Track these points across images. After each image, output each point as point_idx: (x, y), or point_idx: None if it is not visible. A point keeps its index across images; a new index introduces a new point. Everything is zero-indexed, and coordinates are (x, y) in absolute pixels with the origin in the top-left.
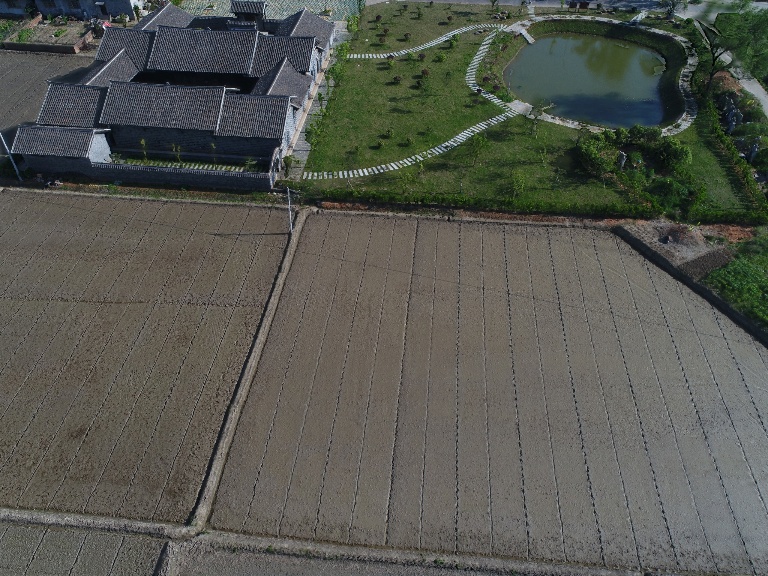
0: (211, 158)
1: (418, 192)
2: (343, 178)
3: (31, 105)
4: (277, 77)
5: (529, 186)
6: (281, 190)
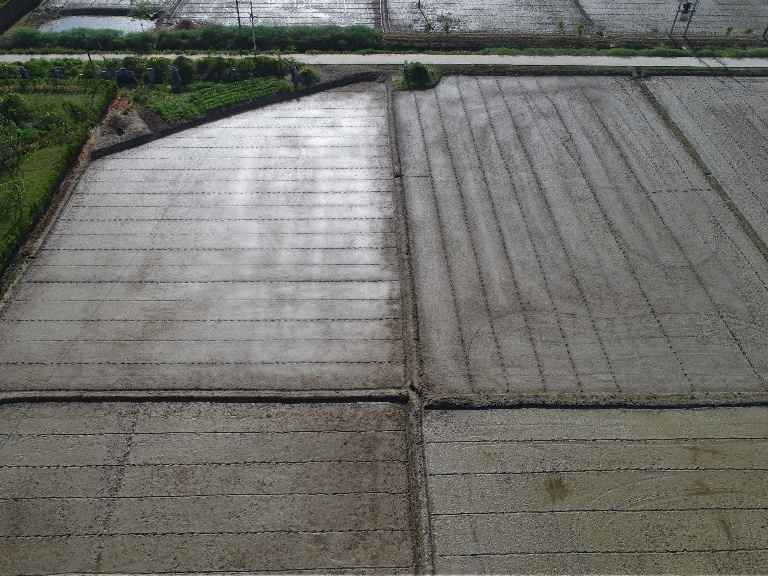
0: None
1: None
2: None
3: None
4: None
5: (5, 197)
6: None
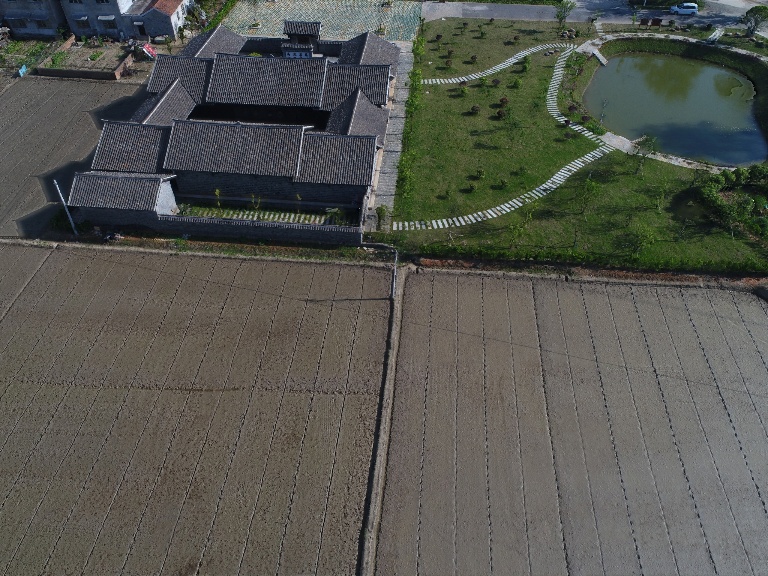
0: (286, 205)
1: (526, 246)
2: (438, 229)
3: (75, 141)
4: (354, 112)
5: None
6: (372, 245)
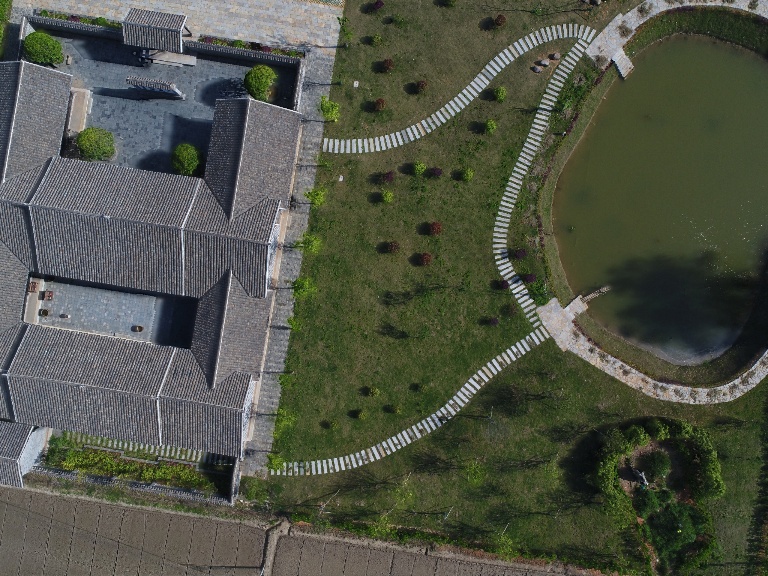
0: None
1: (398, 510)
2: (316, 476)
3: None
4: (222, 333)
5: (523, 509)
6: None
